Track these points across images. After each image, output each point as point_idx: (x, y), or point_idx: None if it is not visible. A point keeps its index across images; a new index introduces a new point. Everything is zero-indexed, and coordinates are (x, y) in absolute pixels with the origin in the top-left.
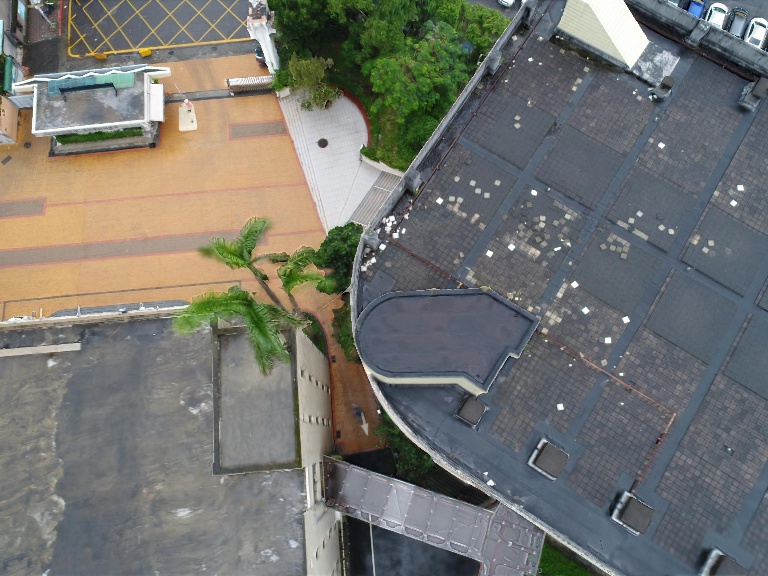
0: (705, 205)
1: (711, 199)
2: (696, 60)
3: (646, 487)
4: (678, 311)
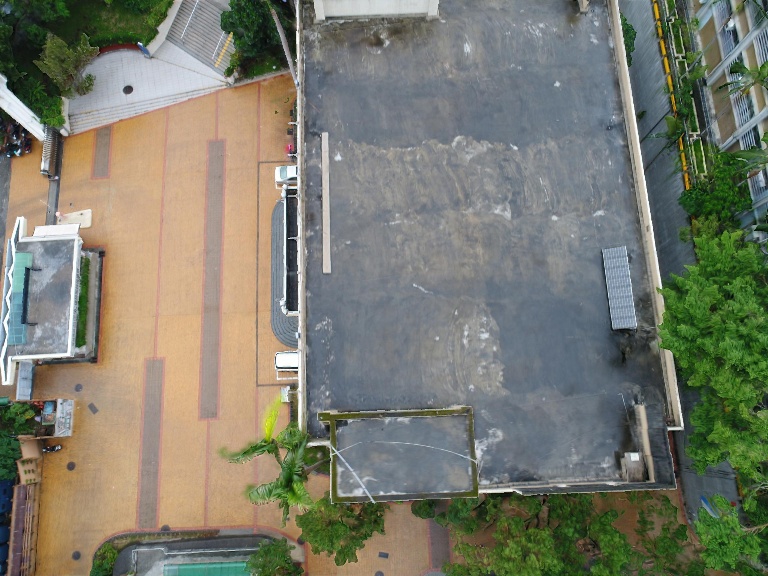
0: None
1: None
2: None
3: None
4: None
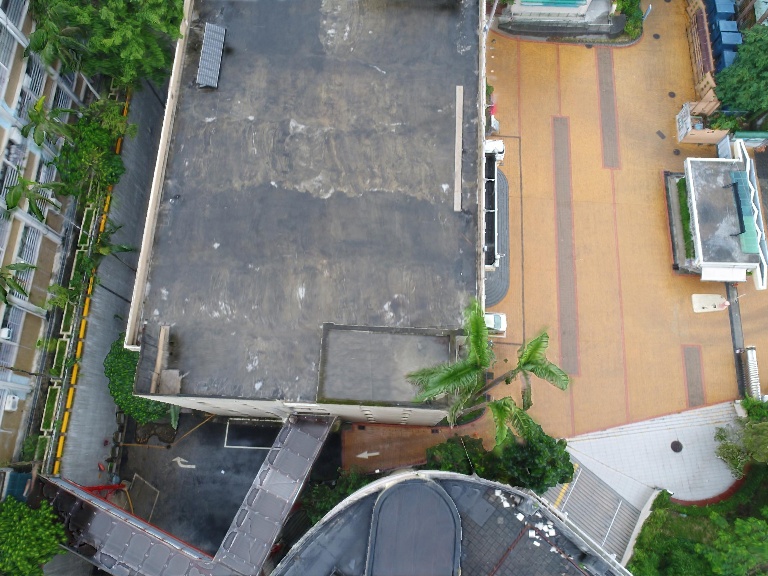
0: None
1: None
2: None
3: None
4: None
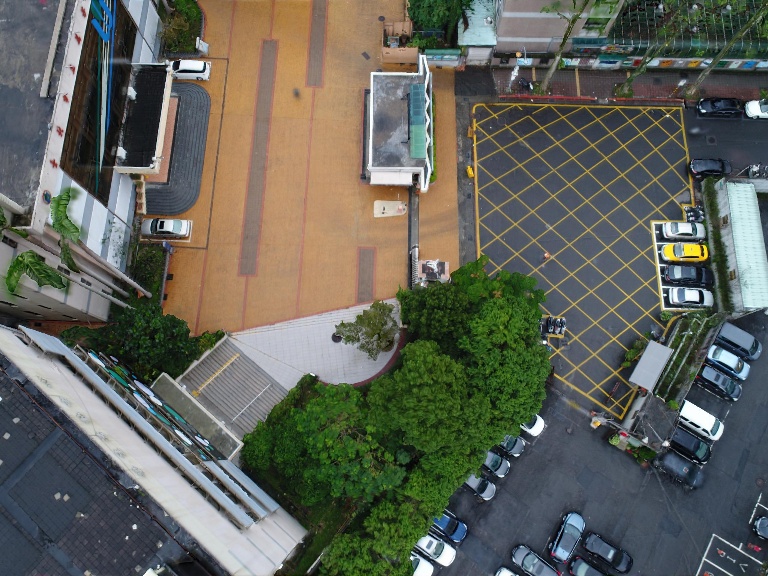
0: None
1: None
2: None
3: None
4: None
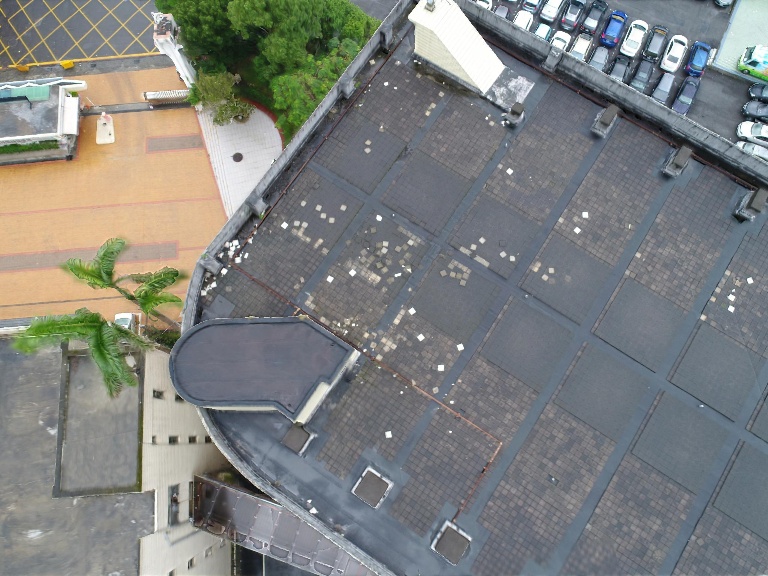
0: (549, 232)
1: (555, 226)
2: (551, 86)
3: (468, 516)
4: (513, 339)
